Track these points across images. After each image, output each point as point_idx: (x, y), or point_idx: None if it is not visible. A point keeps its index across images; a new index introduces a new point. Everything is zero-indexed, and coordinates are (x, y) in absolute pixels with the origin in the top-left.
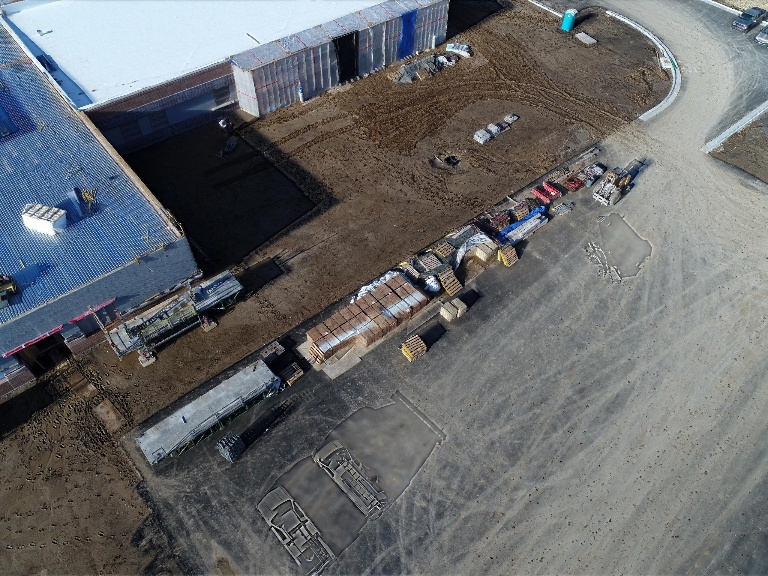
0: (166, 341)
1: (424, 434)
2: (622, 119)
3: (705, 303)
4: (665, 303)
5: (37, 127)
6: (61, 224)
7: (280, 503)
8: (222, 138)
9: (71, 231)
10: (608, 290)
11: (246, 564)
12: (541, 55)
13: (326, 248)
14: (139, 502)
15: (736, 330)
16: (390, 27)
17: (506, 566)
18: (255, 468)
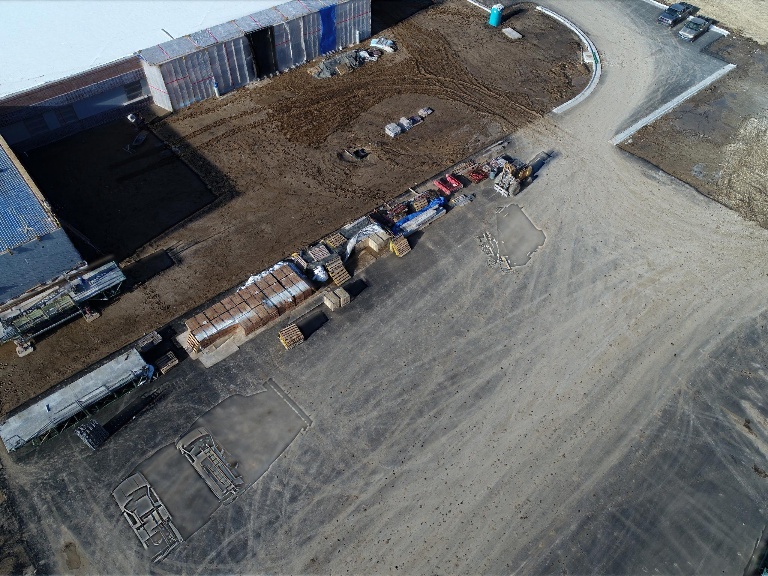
0: (45, 332)
1: (290, 420)
2: (536, 112)
3: (589, 291)
4: (550, 291)
5: None
6: None
7: (136, 489)
8: (132, 132)
9: None
10: (495, 279)
11: (93, 548)
12: (465, 50)
13: (221, 240)
14: None
15: (616, 317)
16: (308, 22)
17: (352, 548)
18: (116, 455)
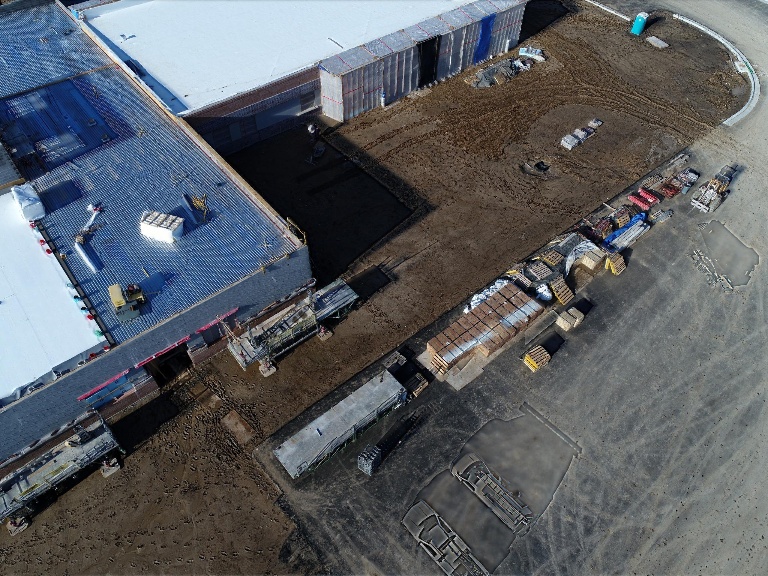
0: (285, 351)
1: (559, 447)
2: (707, 124)
3: None
4: None
5: (136, 133)
6: (179, 232)
7: (425, 518)
8: (309, 143)
9: (189, 239)
10: (721, 299)
11: None
12: (615, 59)
13: (430, 256)
14: (282, 516)
15: None
16: (470, 31)
17: None
18: (394, 482)
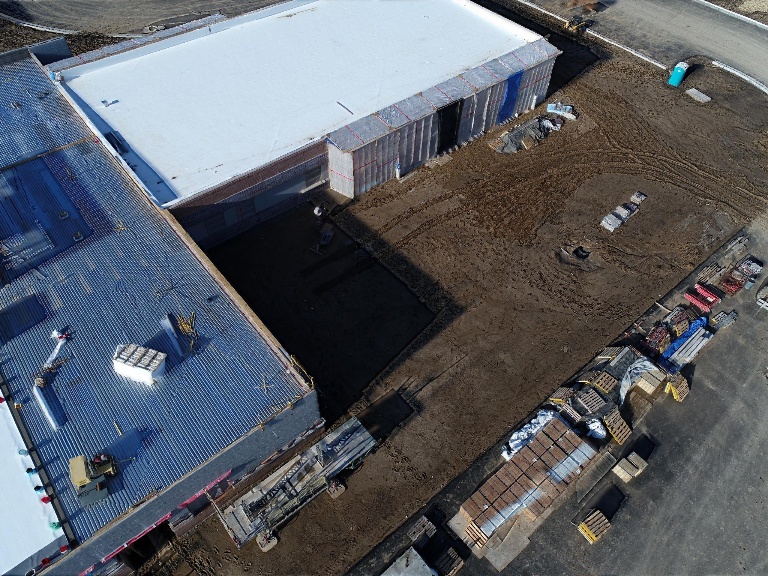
0: (289, 516)
1: None
2: (764, 198)
3: None
4: None
5: (114, 228)
6: (160, 370)
7: None
8: (315, 226)
9: (172, 378)
10: None
11: None
12: (653, 116)
13: (458, 375)
14: None
15: None
16: (495, 91)
17: None
18: None
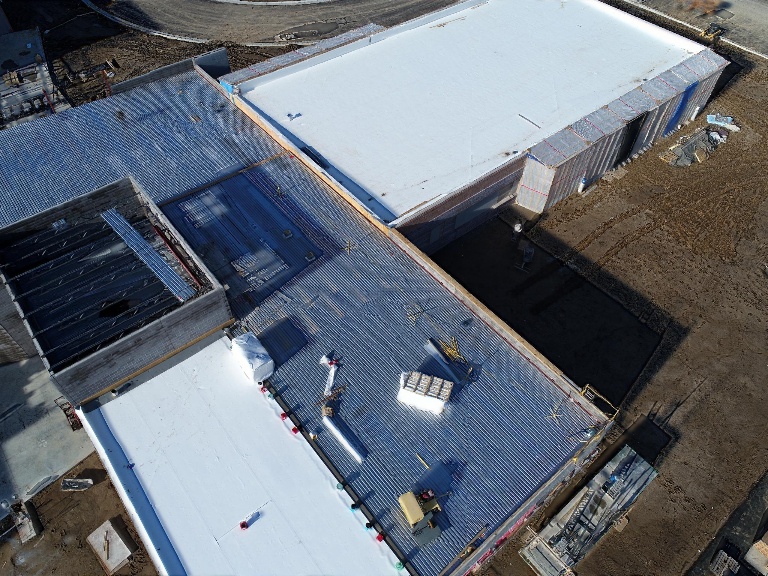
0: None
1: None
2: None
3: None
4: None
5: (342, 248)
6: None
7: None
8: (510, 242)
9: (458, 407)
10: None
11: None
12: None
13: (704, 400)
14: None
15: None
16: (672, 103)
17: None
18: None
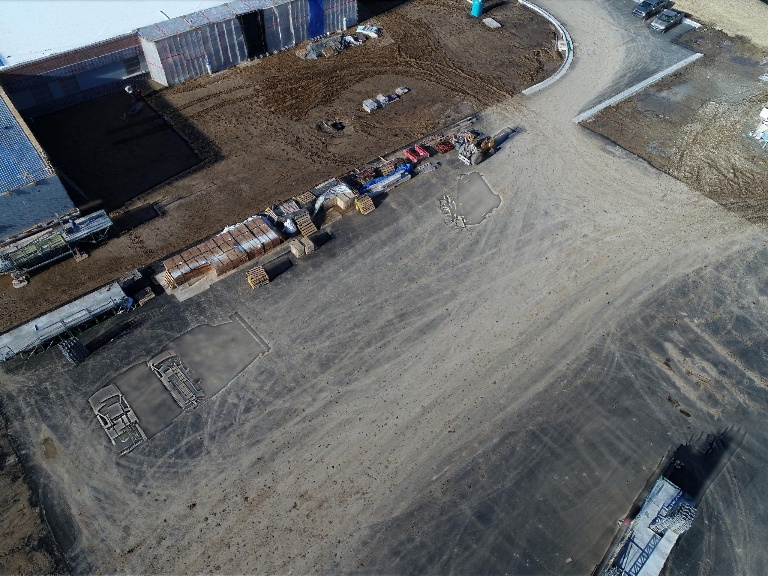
0: (38, 267)
1: (251, 347)
2: (506, 93)
3: (536, 247)
4: (499, 246)
5: None
6: None
7: (109, 397)
8: (130, 103)
9: None
10: (450, 235)
11: (68, 442)
12: (446, 37)
13: (202, 196)
14: None
15: (558, 270)
16: (296, 7)
17: (295, 450)
18: (94, 369)
